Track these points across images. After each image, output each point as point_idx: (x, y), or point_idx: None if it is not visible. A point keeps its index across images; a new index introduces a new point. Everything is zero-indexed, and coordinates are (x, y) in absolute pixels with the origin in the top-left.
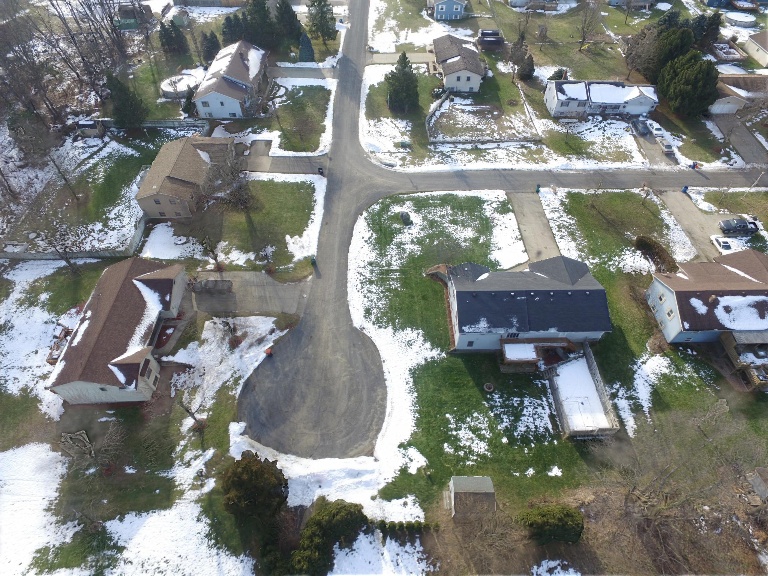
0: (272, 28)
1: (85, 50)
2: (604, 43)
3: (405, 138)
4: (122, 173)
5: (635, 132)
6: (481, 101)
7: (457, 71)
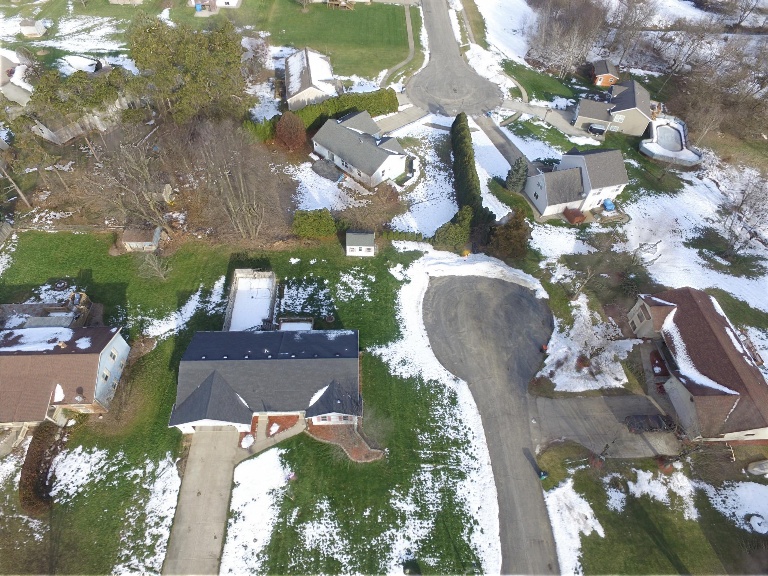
0: None
1: None
2: None
3: None
4: None
5: None
6: None
7: None
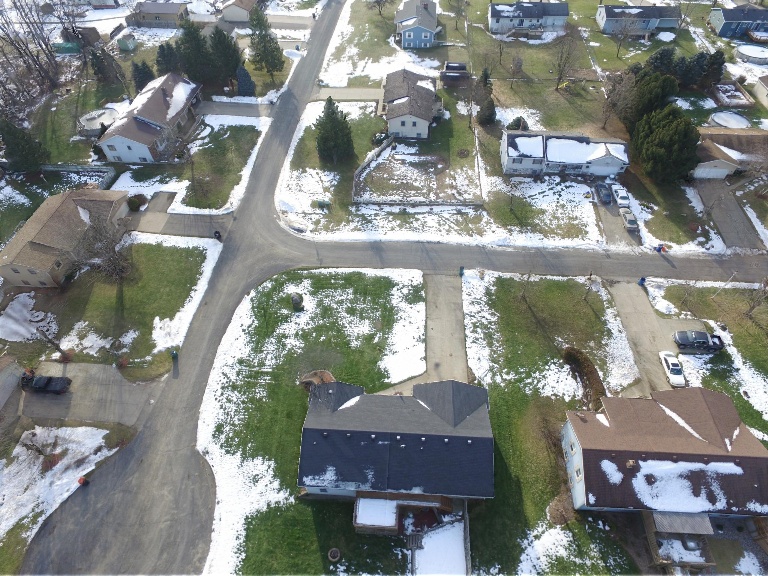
0: (207, 59)
1: (19, 76)
2: (585, 82)
3: (326, 195)
4: (4, 226)
5: (596, 199)
6: (427, 150)
7: (400, 115)
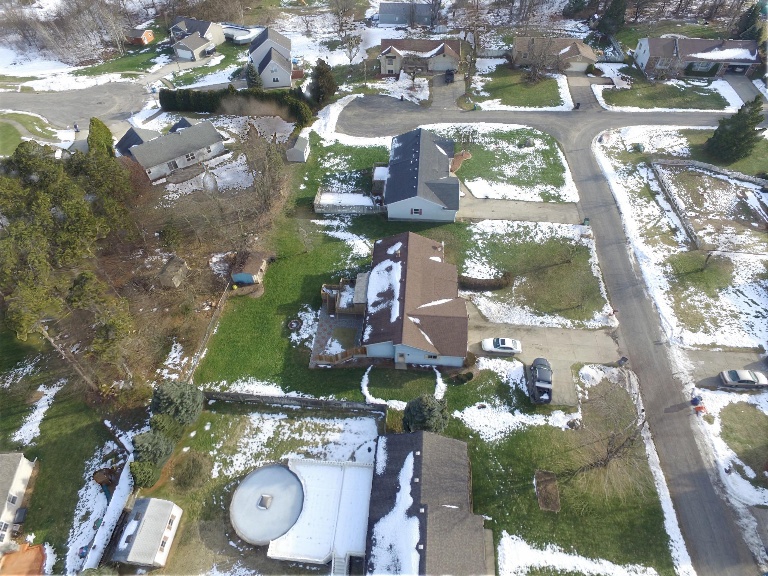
0: None
1: None
2: None
3: (652, 150)
4: None
5: None
6: None
7: None
